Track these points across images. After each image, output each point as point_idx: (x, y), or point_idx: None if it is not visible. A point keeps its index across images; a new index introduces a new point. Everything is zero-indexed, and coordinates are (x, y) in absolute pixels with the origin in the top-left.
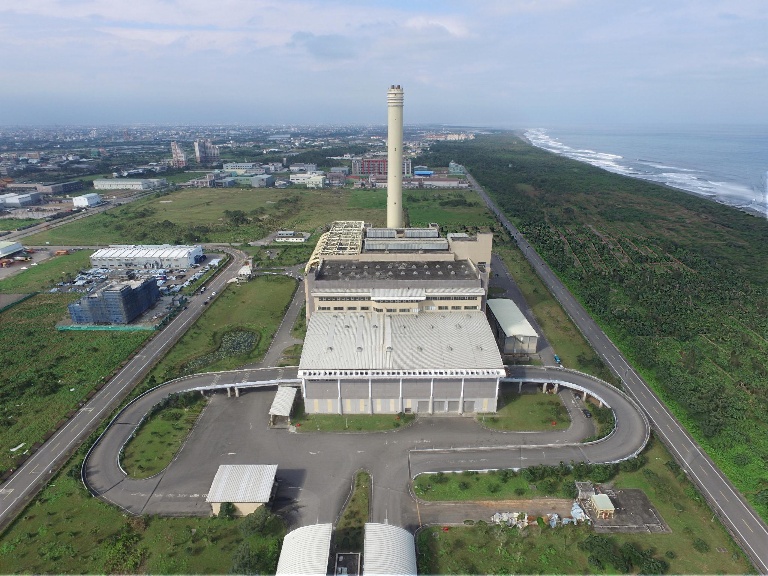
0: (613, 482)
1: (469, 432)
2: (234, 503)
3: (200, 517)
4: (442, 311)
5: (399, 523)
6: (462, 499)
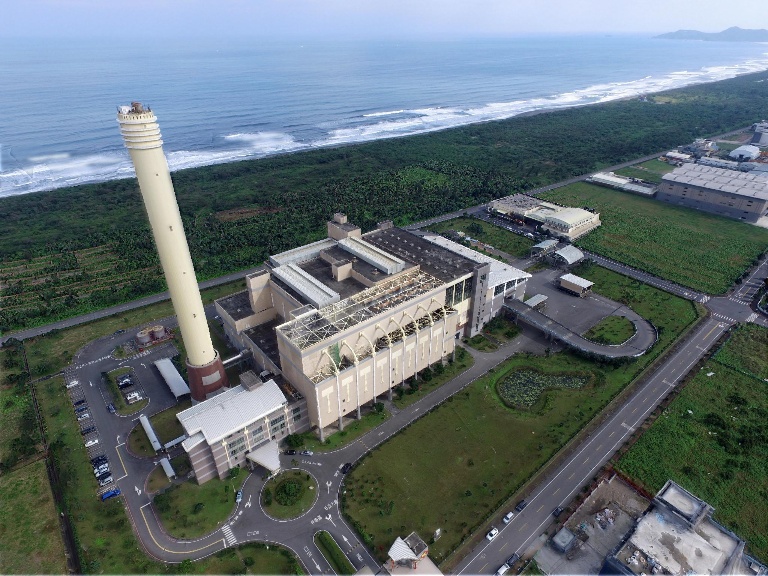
0: None
1: None
2: None
3: None
4: None
5: (524, 261)
6: (496, 255)
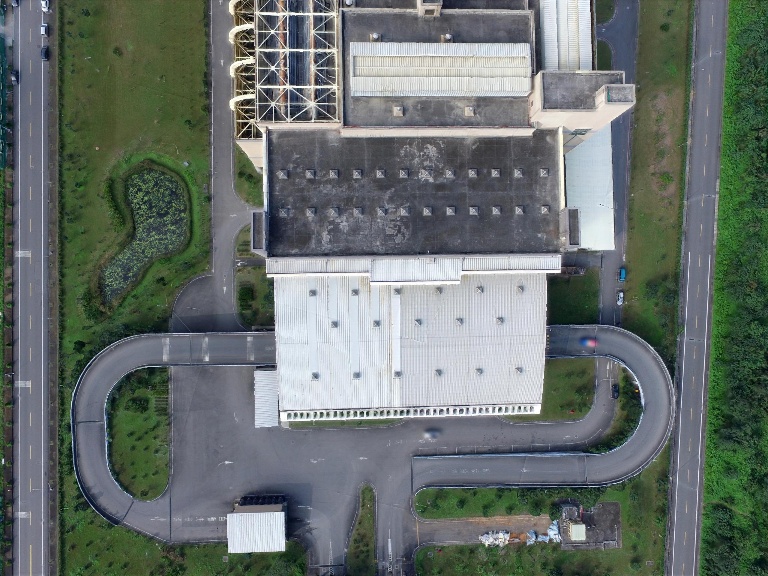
0: None
1: (478, 425)
2: None
3: (226, 543)
4: None
5: (400, 543)
6: (457, 517)
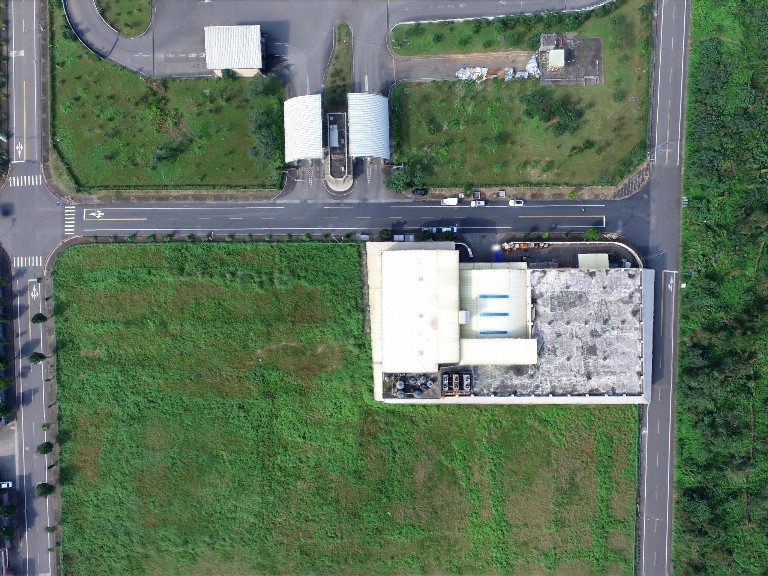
0: (579, 30)
1: None
2: (232, 69)
3: (207, 78)
4: None
5: (377, 80)
6: (434, 53)
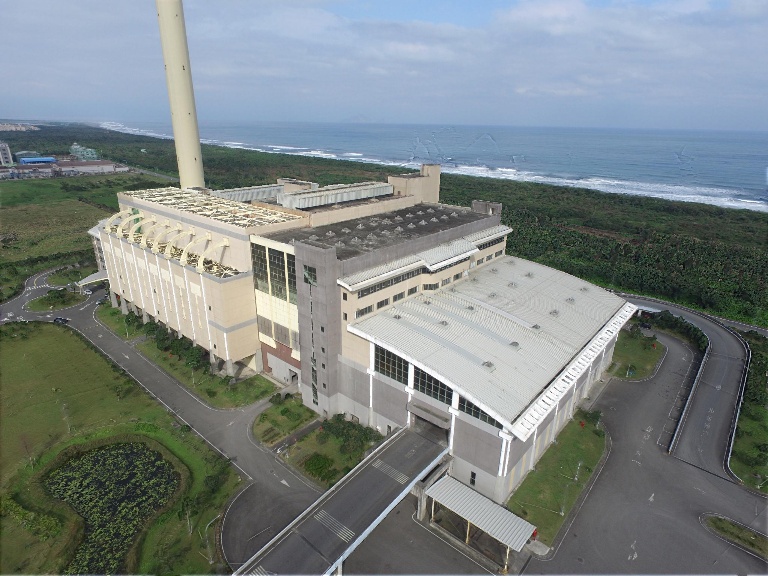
0: None
1: (644, 393)
2: None
3: None
4: (480, 266)
5: None
6: None
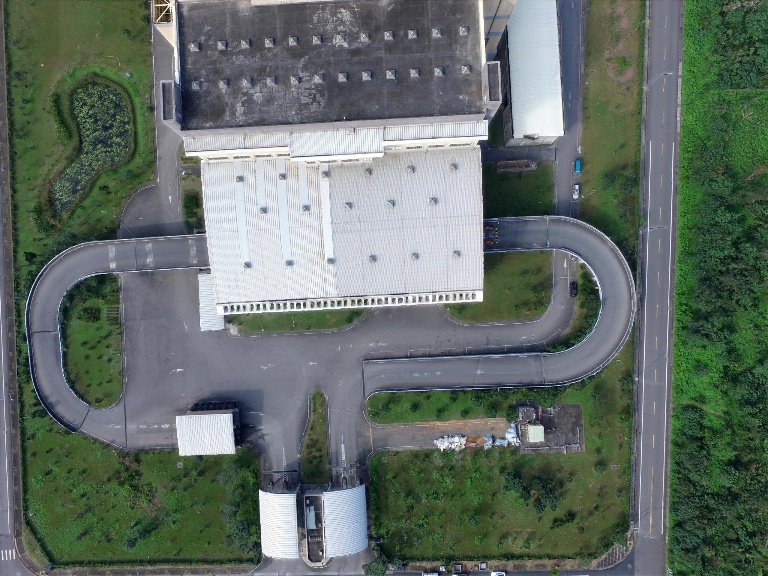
0: (558, 396)
1: (430, 328)
2: (205, 454)
3: None
4: (412, 150)
5: (354, 449)
6: (411, 421)
